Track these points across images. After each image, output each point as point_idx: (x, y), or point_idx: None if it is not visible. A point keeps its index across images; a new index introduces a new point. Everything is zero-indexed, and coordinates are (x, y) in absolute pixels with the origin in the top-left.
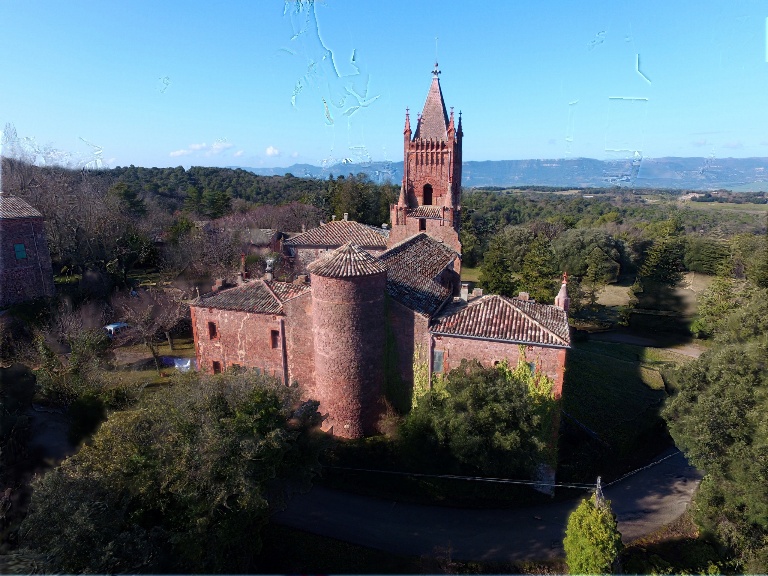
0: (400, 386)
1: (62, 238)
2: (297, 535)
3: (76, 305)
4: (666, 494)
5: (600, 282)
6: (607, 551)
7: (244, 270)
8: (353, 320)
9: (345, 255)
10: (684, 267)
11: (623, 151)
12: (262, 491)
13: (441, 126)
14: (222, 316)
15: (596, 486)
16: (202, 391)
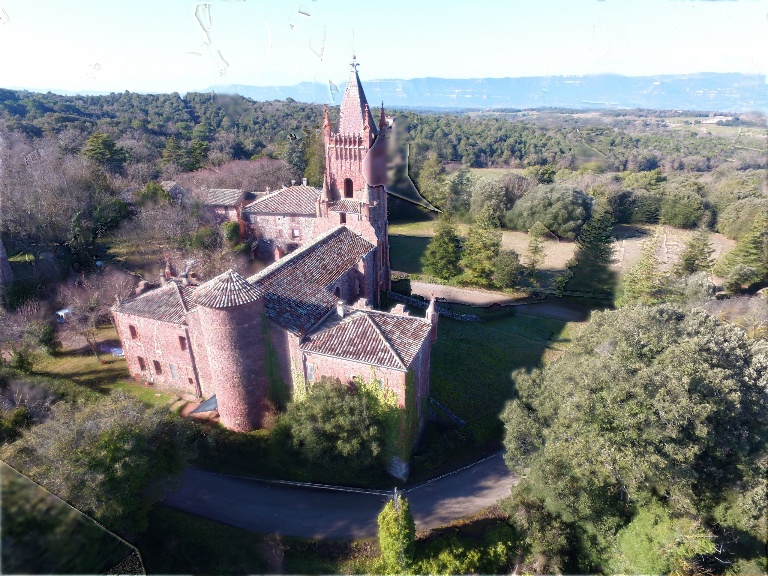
0: (283, 389)
1: (21, 218)
2: (180, 515)
3: (30, 292)
4: (502, 479)
5: (539, 255)
6: (400, 541)
7: (169, 269)
8: (231, 341)
9: (223, 284)
10: (616, 244)
11: (599, 103)
12: (133, 493)
13: (359, 121)
14: (139, 321)
15: (394, 494)
16: (58, 435)
